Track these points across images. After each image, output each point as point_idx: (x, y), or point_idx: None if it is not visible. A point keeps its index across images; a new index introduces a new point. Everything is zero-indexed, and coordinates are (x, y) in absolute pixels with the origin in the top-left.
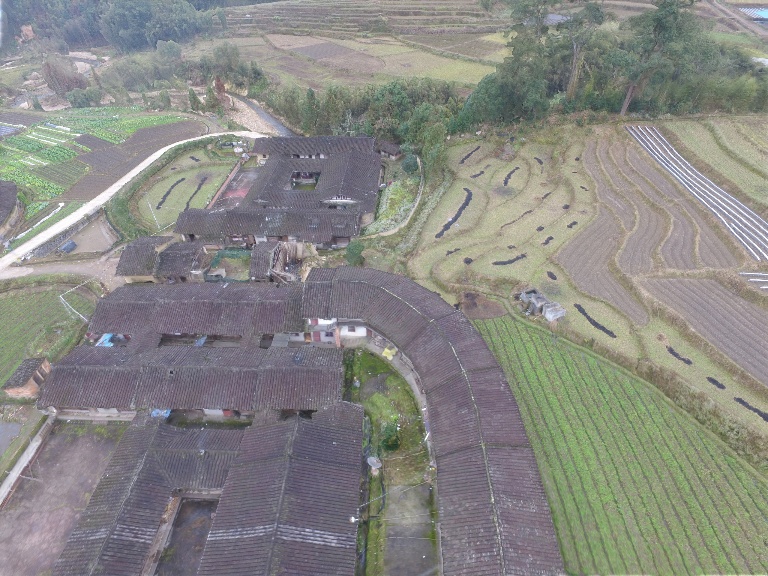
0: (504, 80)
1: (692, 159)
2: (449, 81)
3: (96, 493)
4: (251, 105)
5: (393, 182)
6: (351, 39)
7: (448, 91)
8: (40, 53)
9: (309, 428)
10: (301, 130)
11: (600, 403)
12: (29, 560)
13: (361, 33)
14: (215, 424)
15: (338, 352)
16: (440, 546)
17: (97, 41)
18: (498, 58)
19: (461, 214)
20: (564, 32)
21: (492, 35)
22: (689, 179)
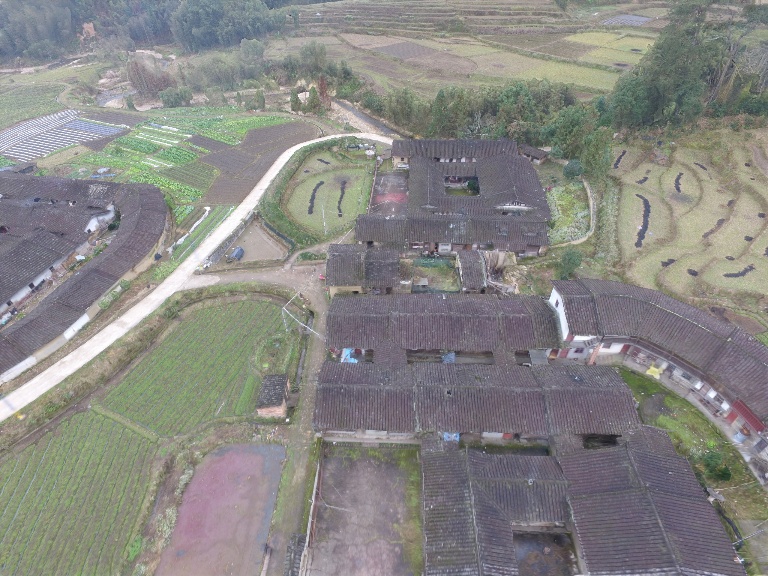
0: (654, 82)
1: None
2: (552, 82)
3: (430, 527)
4: (344, 106)
5: (553, 187)
6: (429, 39)
7: (566, 93)
8: None
9: (641, 456)
10: (410, 132)
11: None
12: None
13: (438, 33)
14: (496, 448)
15: (611, 371)
16: None
17: (159, 39)
18: (593, 59)
19: (649, 222)
20: (712, 33)
21: (574, 36)
22: None
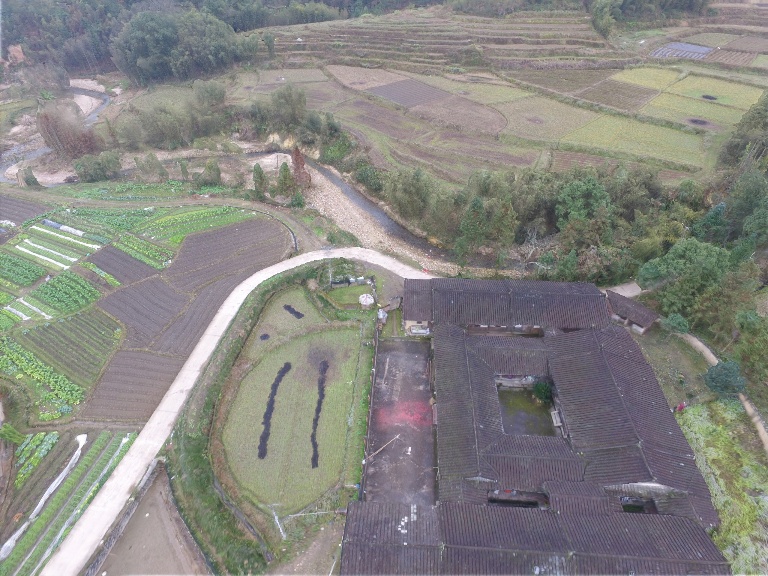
0: None
1: None
2: (613, 151)
3: None
4: (329, 176)
5: (689, 407)
6: (439, 75)
7: (650, 182)
8: None
9: None
10: (423, 231)
11: None
12: None
13: (450, 67)
14: None
15: None
16: None
17: (104, 65)
18: (659, 112)
19: None
20: None
21: (623, 73)
22: None
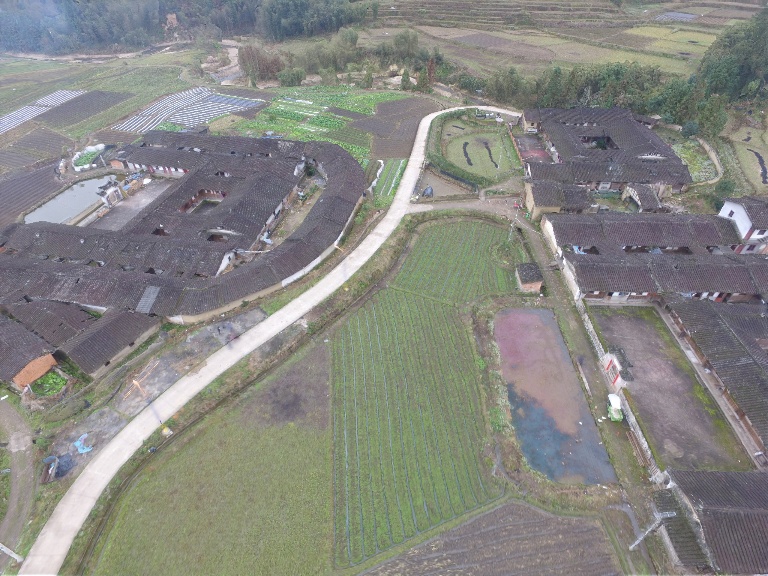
0: (747, 61)
1: None
2: None
3: (700, 341)
4: (439, 87)
5: (673, 145)
6: (500, 31)
7: (653, 74)
8: (186, 40)
9: None
10: None
11: None
12: (666, 387)
13: (507, 26)
14: None
15: None
16: None
17: (236, 30)
18: (658, 49)
19: (766, 167)
20: None
21: (632, 29)
22: None
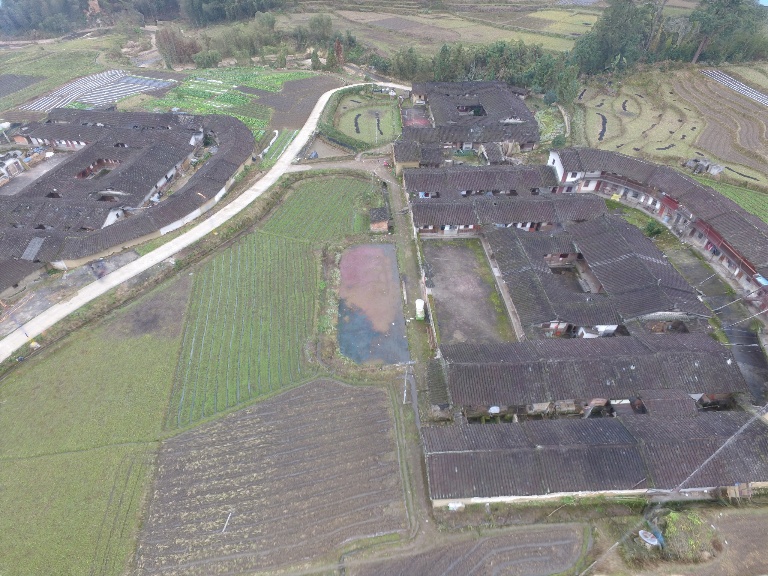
0: (604, 37)
1: (758, 88)
2: None
3: (498, 258)
4: (352, 68)
5: (537, 111)
6: (414, 15)
7: (537, 52)
8: (109, 26)
9: (612, 221)
10: None
11: (766, 210)
12: (469, 295)
13: (422, 10)
14: None
15: None
16: (714, 268)
17: (161, 16)
18: (553, 30)
19: (606, 127)
20: (644, 1)
21: (536, 13)
22: (762, 100)
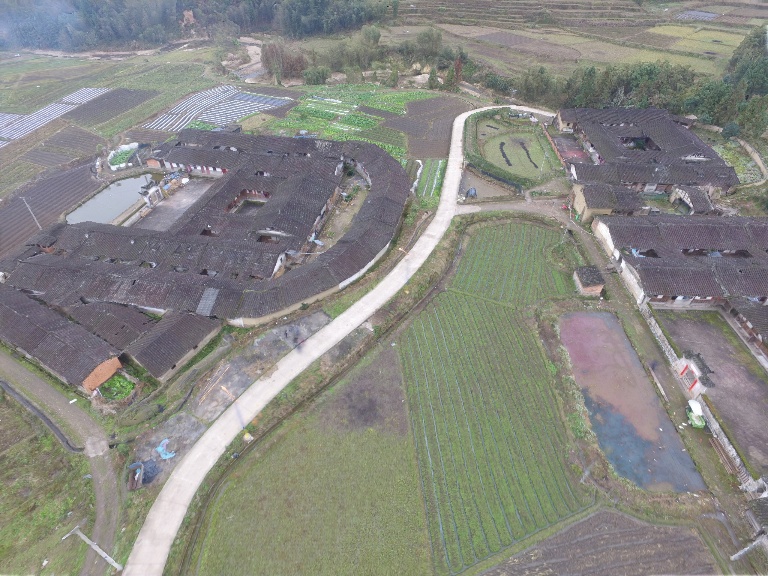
0: None
1: None
2: None
3: None
4: (464, 86)
5: (713, 146)
6: (521, 29)
7: (684, 74)
8: (203, 37)
9: None
10: None
11: None
12: (743, 393)
13: (528, 24)
14: None
15: None
16: None
17: (253, 27)
18: (683, 48)
19: None
20: None
21: (654, 28)
22: None
